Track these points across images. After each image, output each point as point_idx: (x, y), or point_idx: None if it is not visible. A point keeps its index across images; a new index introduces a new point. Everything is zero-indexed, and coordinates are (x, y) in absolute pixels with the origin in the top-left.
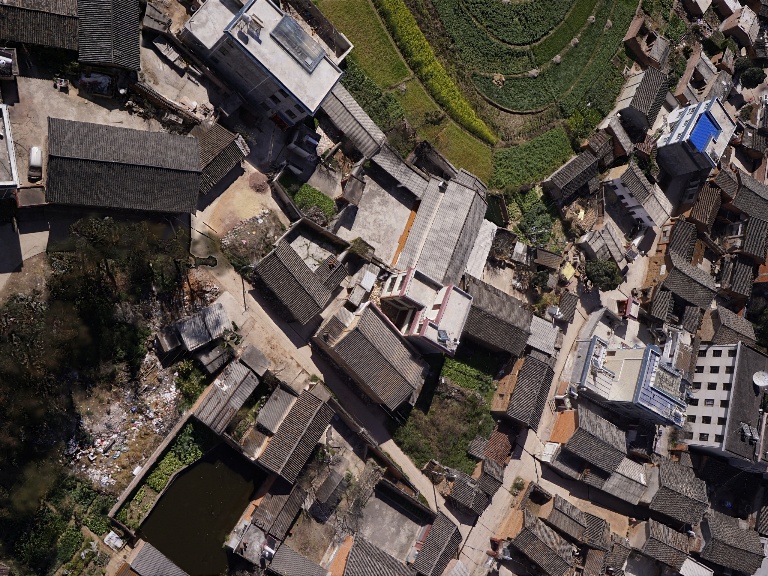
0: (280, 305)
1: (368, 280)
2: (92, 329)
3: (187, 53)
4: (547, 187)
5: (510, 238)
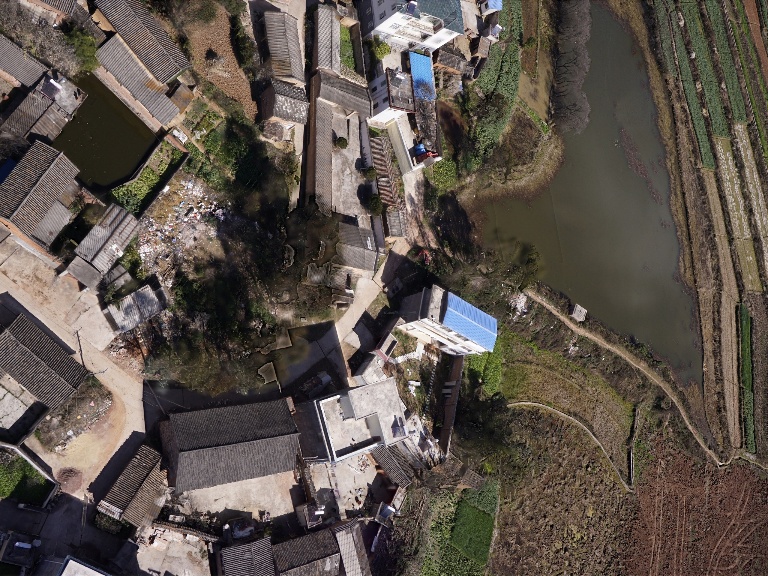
0: None
1: None
2: (221, 307)
3: None
4: None
5: None
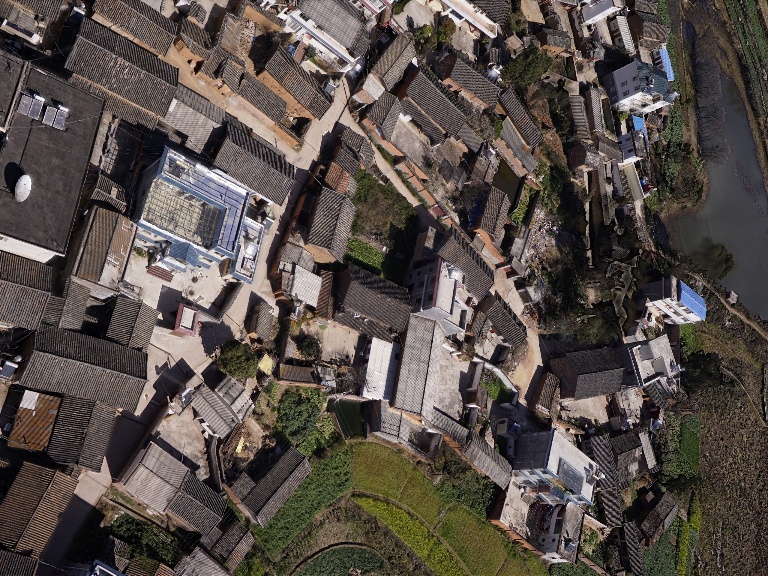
0: None
1: None
2: (565, 289)
3: None
4: None
5: (344, 389)
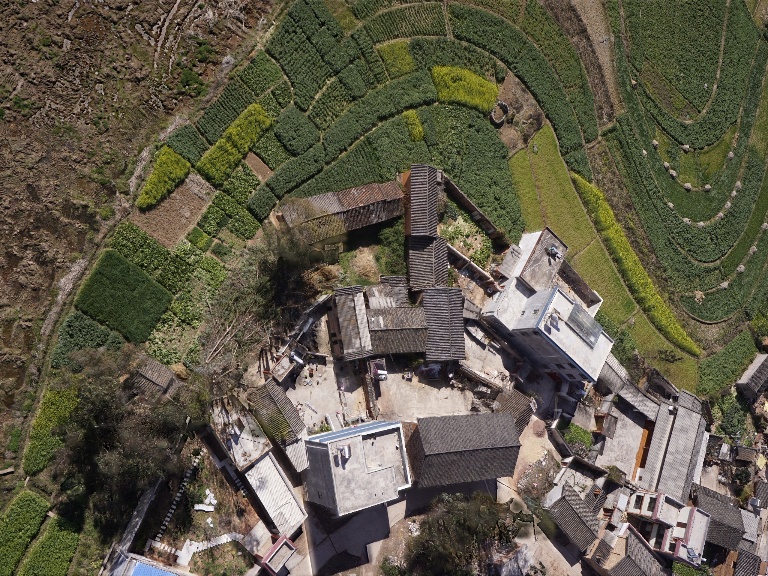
0: (560, 533)
1: (622, 502)
2: None
3: (490, 331)
4: (741, 388)
5: (718, 441)
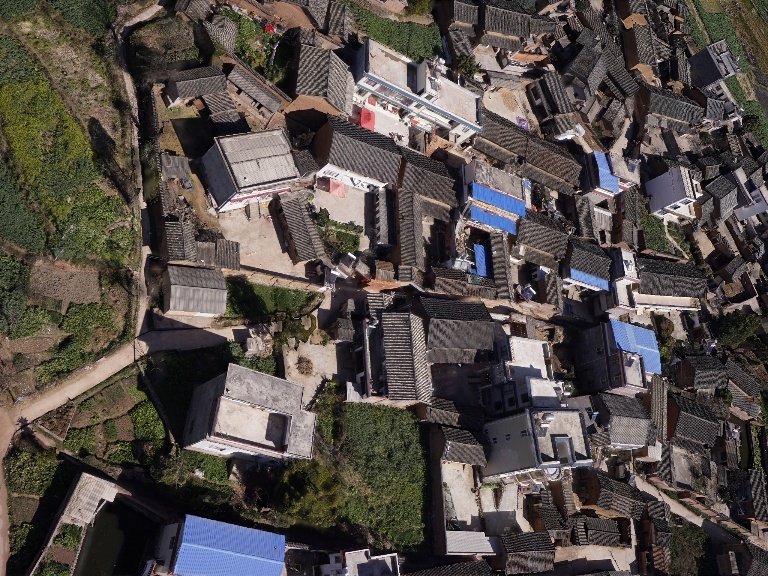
0: None
1: None
2: None
3: None
4: None
5: None
